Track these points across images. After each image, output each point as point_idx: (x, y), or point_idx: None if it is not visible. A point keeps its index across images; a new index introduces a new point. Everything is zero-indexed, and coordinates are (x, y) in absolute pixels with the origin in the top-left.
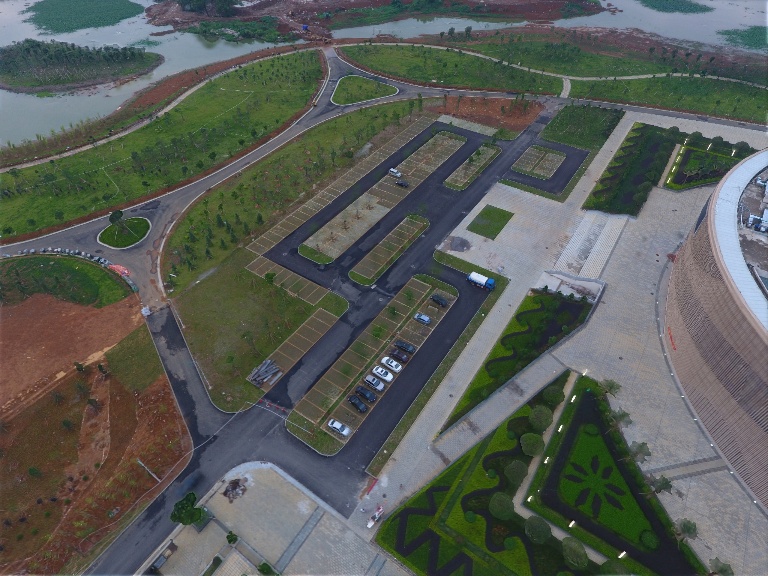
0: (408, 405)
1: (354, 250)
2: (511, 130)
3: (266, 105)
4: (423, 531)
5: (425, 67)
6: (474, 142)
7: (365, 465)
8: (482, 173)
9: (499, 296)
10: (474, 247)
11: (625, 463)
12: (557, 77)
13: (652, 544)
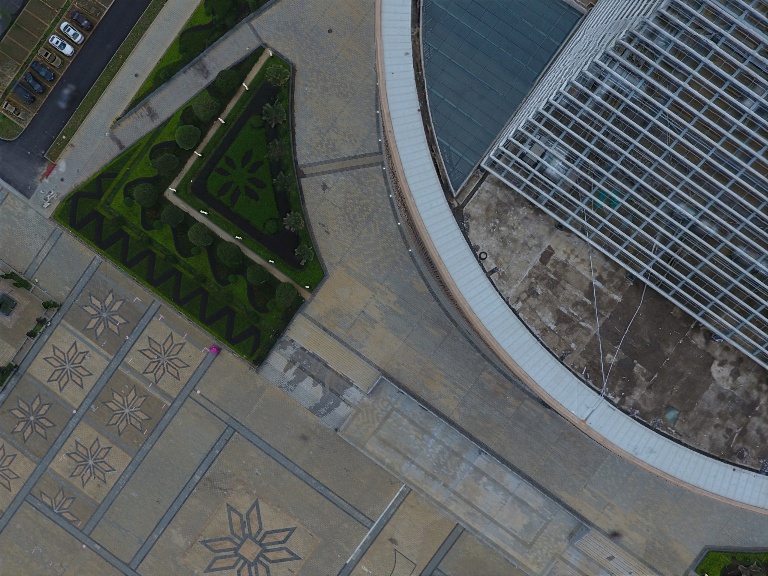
0: (89, 86)
1: None
2: None
3: None
4: (90, 212)
5: None
6: None
7: (44, 150)
8: None
9: None
10: None
11: None
12: None
13: (271, 230)
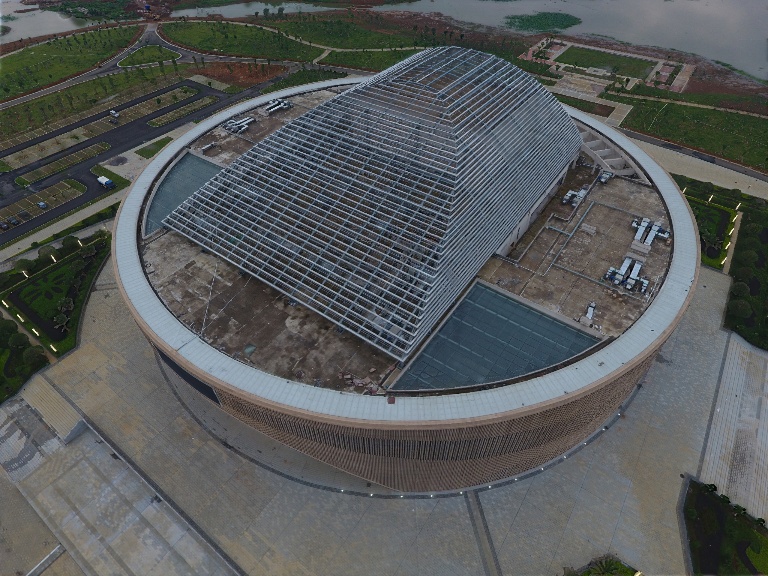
0: None
1: (35, 164)
2: (241, 86)
3: (58, 65)
4: None
5: (215, 39)
6: (202, 94)
7: None
8: (186, 116)
9: (114, 193)
10: (128, 163)
11: (85, 279)
12: (323, 48)
13: (49, 315)
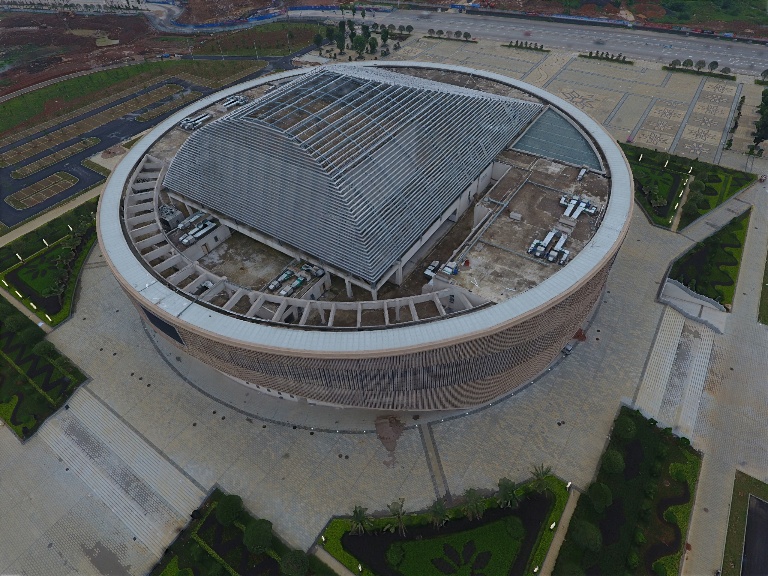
0: None
1: None
2: None
3: None
4: None
5: None
6: None
7: None
8: None
9: (761, 302)
10: None
11: None
12: None
13: None
